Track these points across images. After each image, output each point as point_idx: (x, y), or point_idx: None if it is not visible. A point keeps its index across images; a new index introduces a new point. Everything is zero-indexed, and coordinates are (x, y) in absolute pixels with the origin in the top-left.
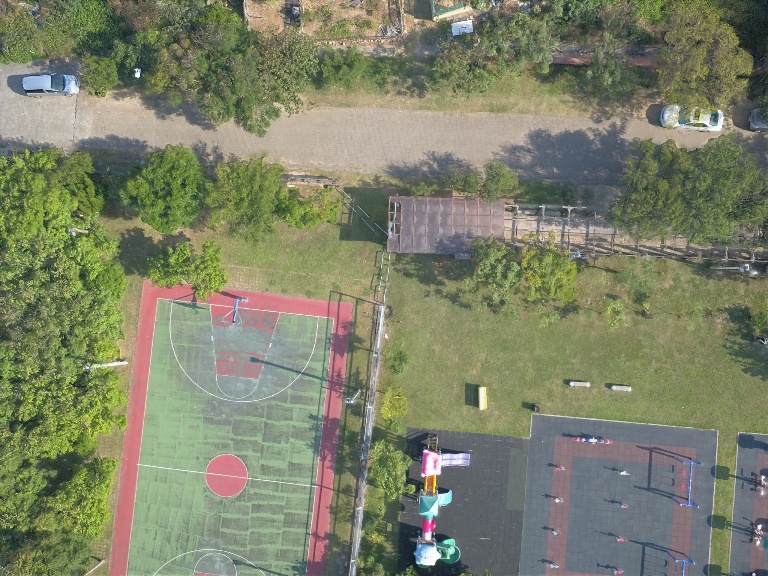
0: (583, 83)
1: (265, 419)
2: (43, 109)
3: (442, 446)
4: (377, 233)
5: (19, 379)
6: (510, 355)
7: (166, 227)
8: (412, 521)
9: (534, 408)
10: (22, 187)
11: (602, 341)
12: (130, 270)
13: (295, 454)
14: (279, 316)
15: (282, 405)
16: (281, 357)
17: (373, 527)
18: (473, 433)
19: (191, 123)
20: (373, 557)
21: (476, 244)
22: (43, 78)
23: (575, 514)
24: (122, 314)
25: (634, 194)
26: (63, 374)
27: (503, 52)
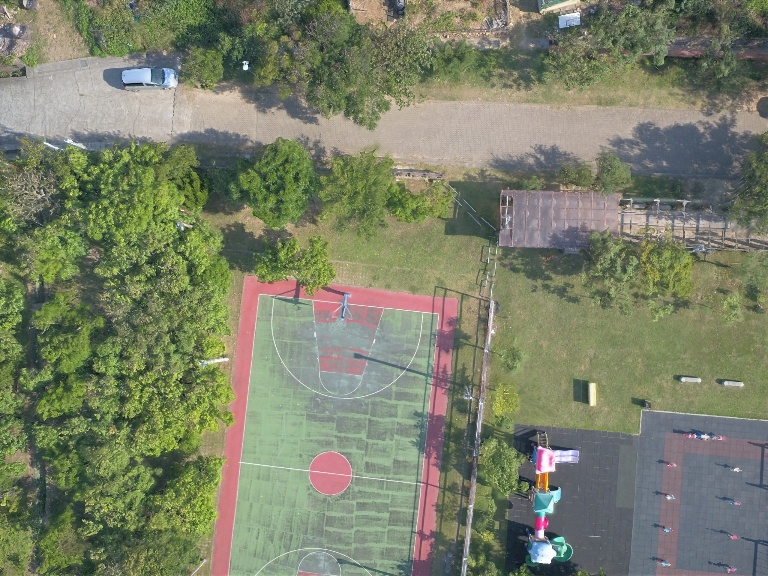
0: (692, 76)
1: (369, 416)
2: (140, 103)
3: (550, 443)
4: (483, 228)
5: (123, 376)
6: (619, 351)
7: (277, 221)
8: (520, 519)
9: (645, 404)
10: (132, 181)
11: (713, 336)
12: (231, 265)
13: (400, 451)
14: (383, 312)
15: (387, 402)
16: (385, 353)
17: (484, 525)
18: (582, 430)
19: (292, 117)
20: (484, 555)
21: (593, 238)
22: (143, 71)
23: (686, 511)
24: (228, 310)
25: (758, 187)
26: (172, 370)
27: (620, 44)
